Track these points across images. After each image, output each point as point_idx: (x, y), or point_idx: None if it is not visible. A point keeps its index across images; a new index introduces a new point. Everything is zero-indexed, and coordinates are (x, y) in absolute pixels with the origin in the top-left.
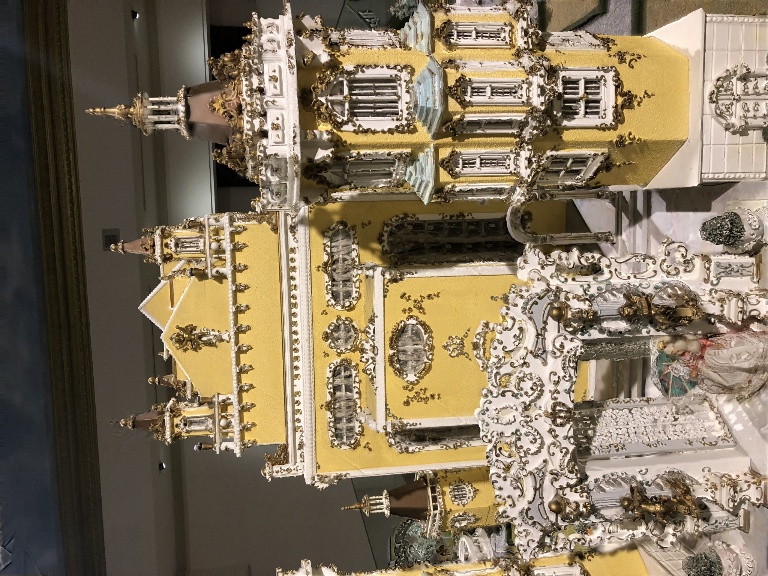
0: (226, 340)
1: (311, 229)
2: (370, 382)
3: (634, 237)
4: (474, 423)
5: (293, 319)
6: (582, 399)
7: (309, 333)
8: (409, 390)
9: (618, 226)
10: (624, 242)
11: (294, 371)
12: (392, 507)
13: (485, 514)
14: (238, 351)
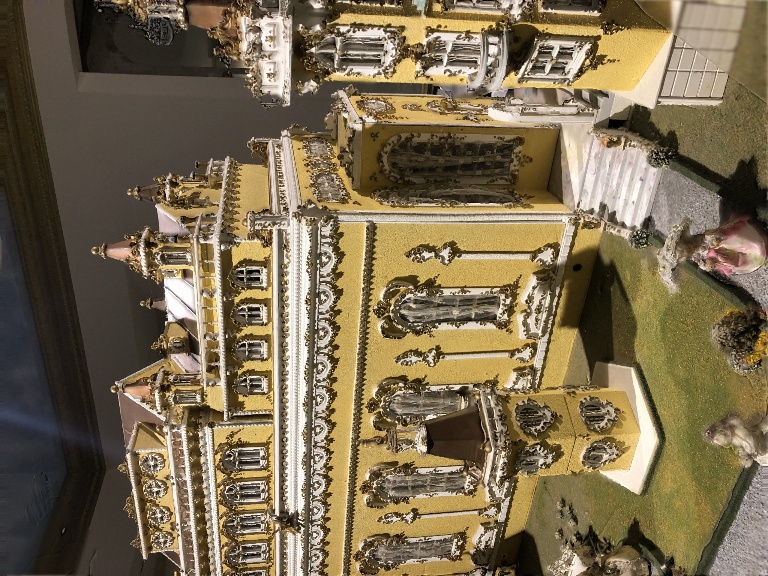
0: (216, 205)
1: (293, 140)
2: (343, 112)
3: None
4: (446, 124)
5: (278, 169)
6: (542, 126)
7: (292, 163)
8: (379, 115)
9: None
10: None
11: (279, 184)
12: (428, 425)
13: (564, 410)
14: (227, 194)
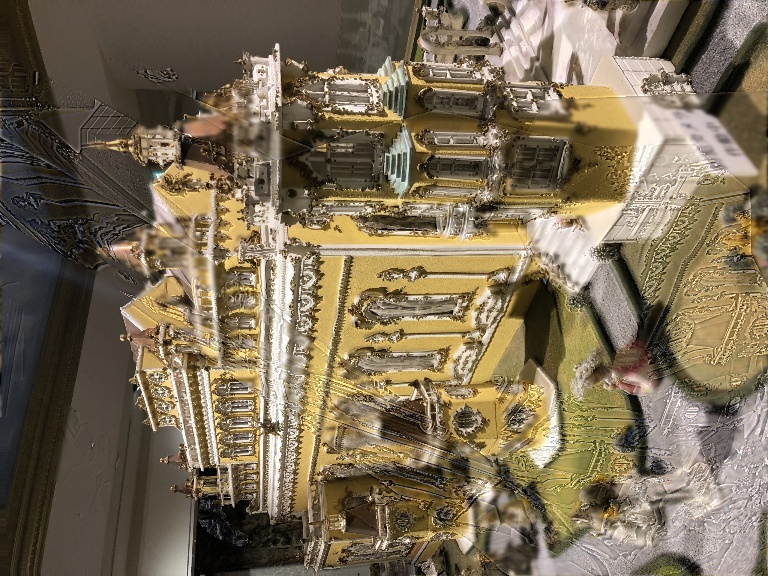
0: None
1: None
2: None
3: (512, 32)
4: None
5: None
6: None
7: None
8: None
9: (501, 38)
10: (507, 39)
11: None
12: None
13: None
14: None
